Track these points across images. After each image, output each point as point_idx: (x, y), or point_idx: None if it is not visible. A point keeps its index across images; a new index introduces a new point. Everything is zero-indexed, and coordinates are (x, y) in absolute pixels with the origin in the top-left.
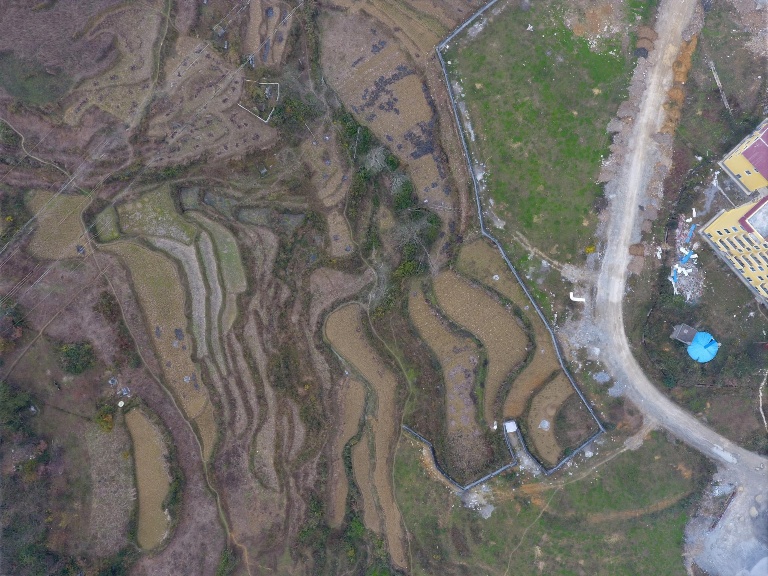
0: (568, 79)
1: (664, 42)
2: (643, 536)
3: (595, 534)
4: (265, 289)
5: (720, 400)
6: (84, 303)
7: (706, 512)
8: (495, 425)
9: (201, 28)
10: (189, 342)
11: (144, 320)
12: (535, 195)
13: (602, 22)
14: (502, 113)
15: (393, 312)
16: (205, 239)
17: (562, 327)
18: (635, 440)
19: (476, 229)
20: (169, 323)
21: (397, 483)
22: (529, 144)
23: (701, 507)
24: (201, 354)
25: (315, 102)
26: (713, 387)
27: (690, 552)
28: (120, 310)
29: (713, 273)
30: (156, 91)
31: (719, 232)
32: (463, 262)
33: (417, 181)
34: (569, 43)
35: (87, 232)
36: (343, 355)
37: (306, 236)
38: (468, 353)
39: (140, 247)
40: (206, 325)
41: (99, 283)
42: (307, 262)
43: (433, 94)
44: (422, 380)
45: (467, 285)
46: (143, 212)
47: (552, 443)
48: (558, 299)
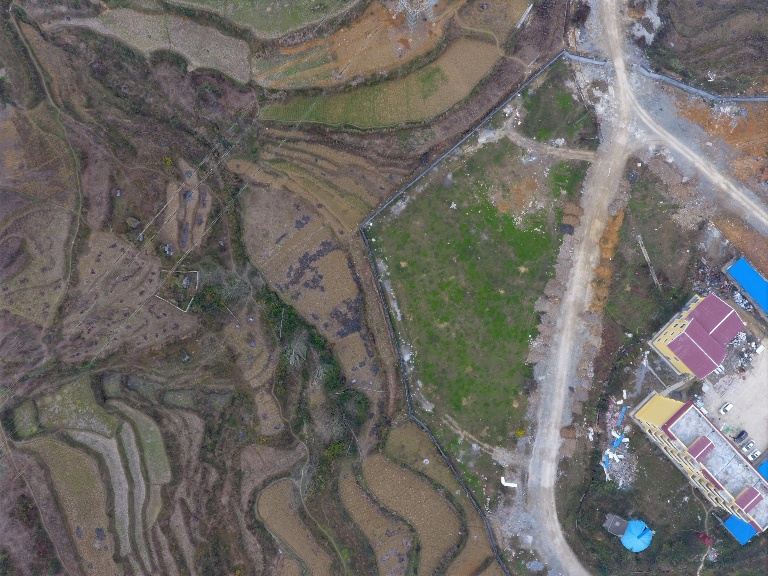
0: (494, 257)
1: (590, 217)
2: None
3: None
4: (192, 476)
5: None
6: (0, 508)
7: None
8: None
9: (115, 222)
10: (111, 542)
11: (64, 521)
12: (463, 377)
13: (527, 198)
14: (428, 292)
15: (324, 494)
16: (127, 430)
17: (495, 512)
18: None
19: (405, 412)
20: (90, 522)
21: None
22: (456, 324)
23: None
24: (124, 552)
25: (238, 283)
26: (649, 573)
27: None
28: (38, 513)
29: (645, 457)
30: (69, 290)
31: (647, 423)
32: (392, 446)
33: (344, 361)
34: (494, 220)
35: (4, 431)
36: (276, 533)
37: (234, 414)
38: (401, 536)
39: (59, 444)
40: (129, 521)
41: (16, 486)
42: (236, 441)
43: (358, 271)
44: (356, 562)
45: (397, 468)
46: (63, 405)
47: None
48: (490, 483)
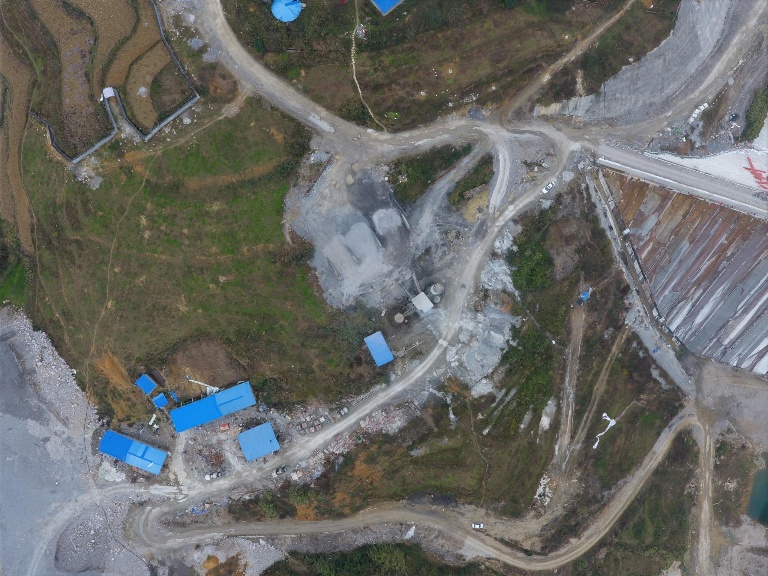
0: None
1: None
2: (244, 205)
3: (196, 202)
4: None
5: (317, 70)
6: None
7: (303, 180)
8: (101, 97)
9: None
10: None
11: None
12: None
13: None
14: None
15: None
16: None
17: None
18: (232, 107)
19: None
20: None
21: (24, 169)
22: None
23: (300, 176)
24: None
25: None
26: (304, 52)
27: (287, 218)
28: None
29: None
30: None
31: None
32: None
33: None
34: None
35: None
36: None
37: None
38: (85, 35)
39: None
40: None
41: None
42: None
43: None
44: (47, 67)
45: None
46: None
47: (149, 109)
48: None
